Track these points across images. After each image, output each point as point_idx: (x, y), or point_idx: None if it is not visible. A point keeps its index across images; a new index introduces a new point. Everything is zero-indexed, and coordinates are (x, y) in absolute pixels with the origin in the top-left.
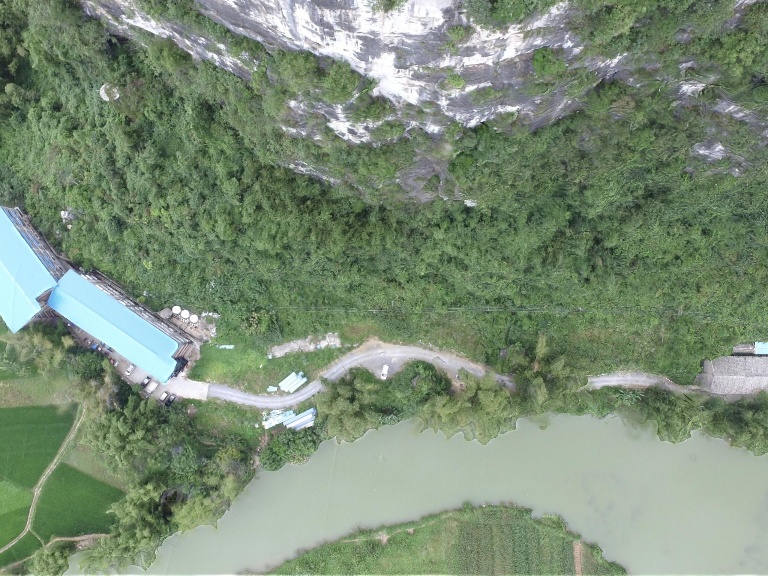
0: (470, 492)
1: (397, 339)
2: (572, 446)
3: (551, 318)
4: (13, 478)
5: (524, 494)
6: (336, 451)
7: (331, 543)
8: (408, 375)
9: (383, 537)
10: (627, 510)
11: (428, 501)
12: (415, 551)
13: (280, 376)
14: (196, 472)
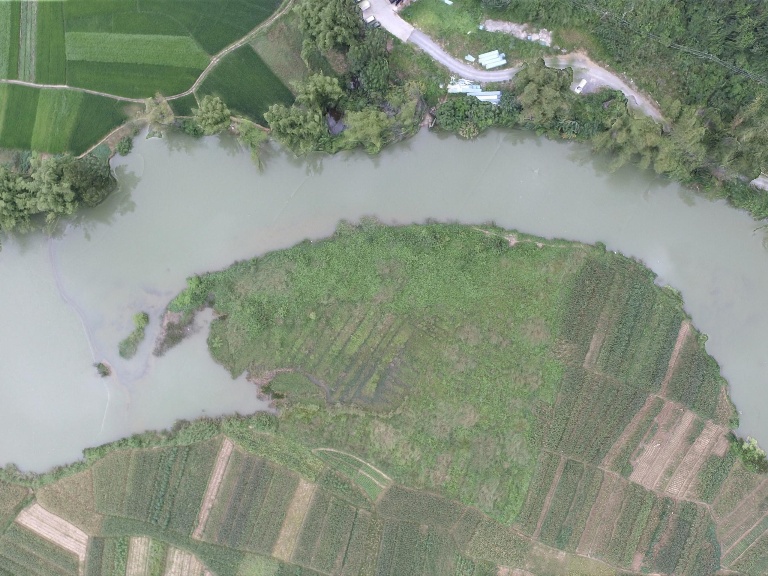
0: (607, 235)
1: (605, 60)
2: (717, 236)
3: (761, 95)
4: (198, 38)
5: (655, 260)
6: (499, 147)
7: (462, 225)
8: (602, 97)
9: (512, 240)
10: (743, 315)
11: (565, 227)
12: (536, 264)
13: (482, 49)
14: (379, 90)
